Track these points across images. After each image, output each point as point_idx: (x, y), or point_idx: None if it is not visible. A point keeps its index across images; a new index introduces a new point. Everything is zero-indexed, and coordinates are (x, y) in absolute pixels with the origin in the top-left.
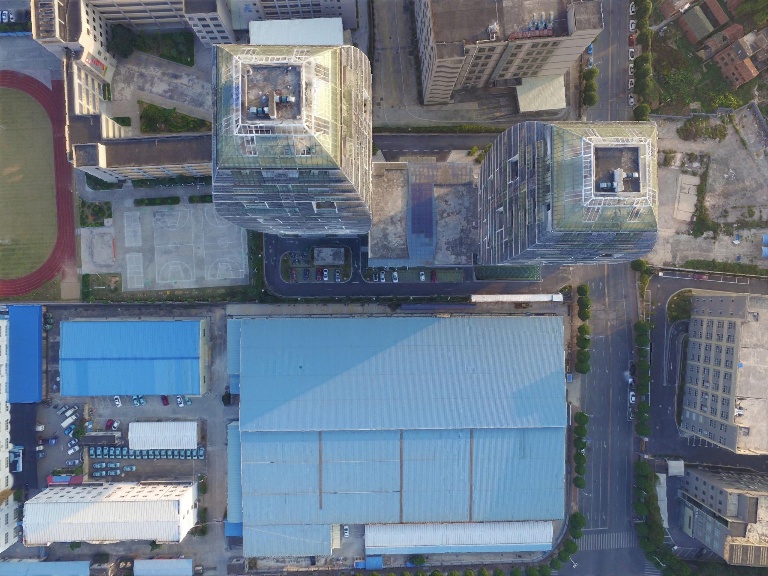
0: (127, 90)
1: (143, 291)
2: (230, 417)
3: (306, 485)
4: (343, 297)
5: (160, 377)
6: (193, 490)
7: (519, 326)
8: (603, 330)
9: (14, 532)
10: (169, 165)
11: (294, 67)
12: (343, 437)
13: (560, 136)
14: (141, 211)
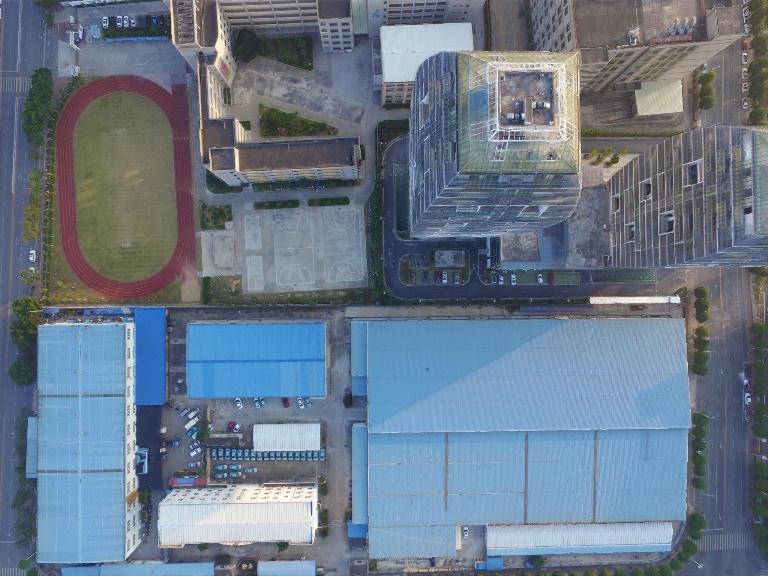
0: (247, 94)
1: (263, 294)
2: (350, 419)
3: (432, 486)
4: (462, 299)
5: (286, 379)
6: (316, 492)
7: (642, 328)
8: (718, 332)
9: (138, 534)
10: (301, 169)
11: (546, 74)
12: (469, 439)
13: (764, 141)
14: (261, 214)
